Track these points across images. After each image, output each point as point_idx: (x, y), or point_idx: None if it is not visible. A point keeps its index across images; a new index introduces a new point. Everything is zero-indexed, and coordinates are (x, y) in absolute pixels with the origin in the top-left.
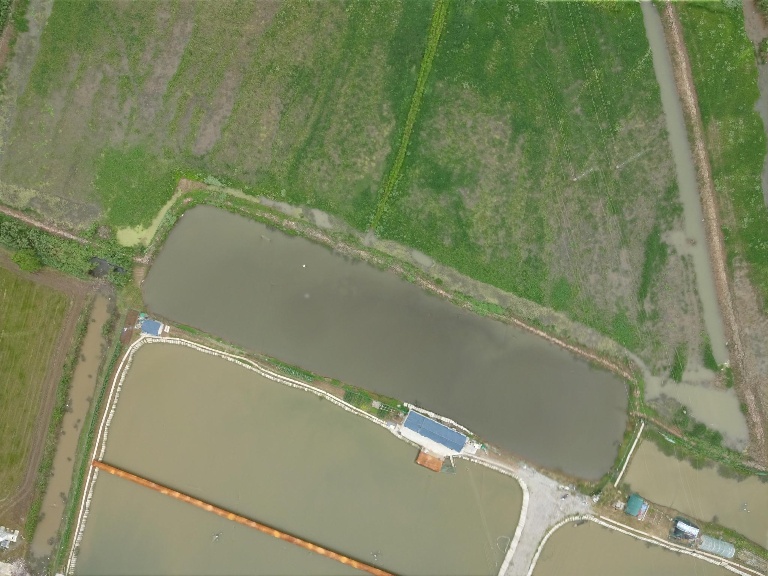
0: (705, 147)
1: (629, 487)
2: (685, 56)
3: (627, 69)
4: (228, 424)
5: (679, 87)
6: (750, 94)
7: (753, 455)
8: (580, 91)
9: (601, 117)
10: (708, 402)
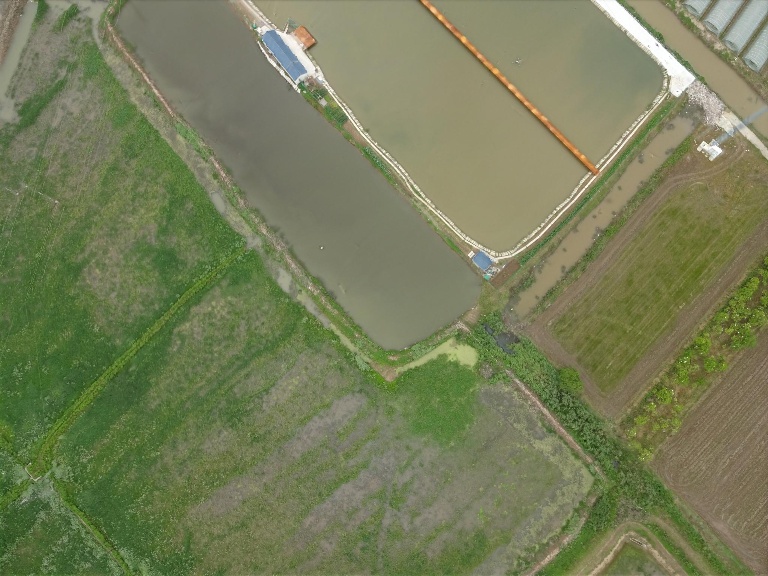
0: None
1: None
2: None
3: None
4: (459, 148)
5: None
6: None
7: None
8: (8, 272)
9: (5, 242)
10: None
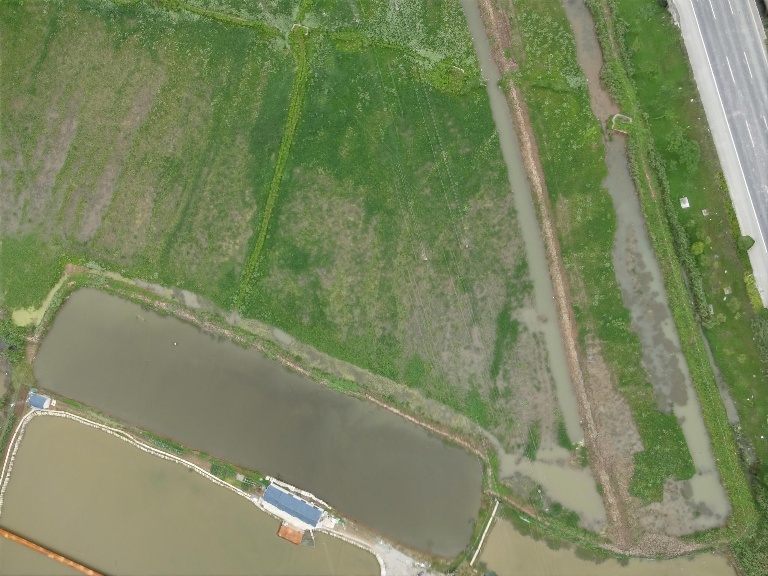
0: (553, 225)
1: (485, 566)
2: (530, 136)
3: (474, 150)
4: (108, 493)
5: (526, 166)
6: (597, 171)
7: (611, 537)
8: (429, 173)
9: (450, 198)
10: (563, 481)
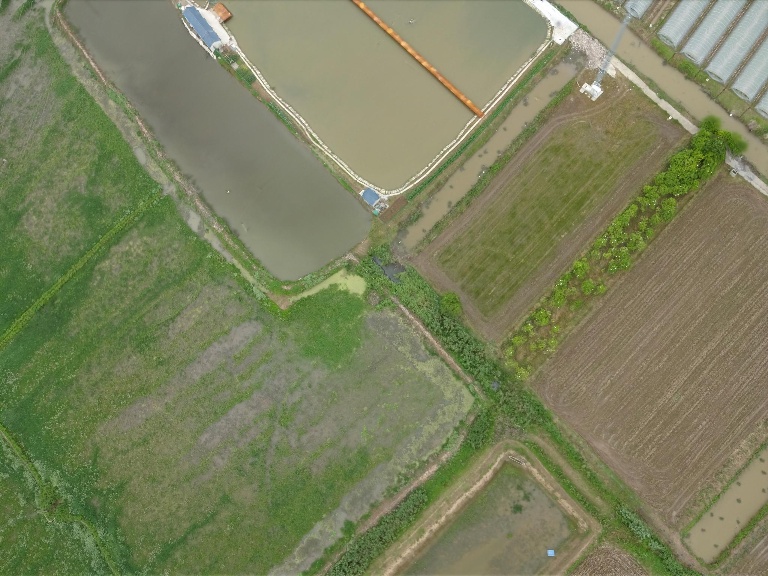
0: None
1: None
2: None
3: None
4: (356, 100)
5: None
6: None
7: None
8: None
9: None
10: None
